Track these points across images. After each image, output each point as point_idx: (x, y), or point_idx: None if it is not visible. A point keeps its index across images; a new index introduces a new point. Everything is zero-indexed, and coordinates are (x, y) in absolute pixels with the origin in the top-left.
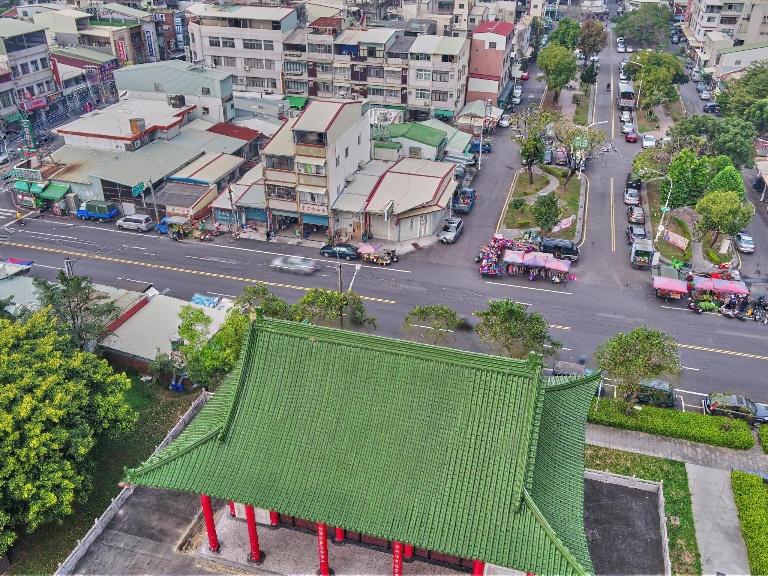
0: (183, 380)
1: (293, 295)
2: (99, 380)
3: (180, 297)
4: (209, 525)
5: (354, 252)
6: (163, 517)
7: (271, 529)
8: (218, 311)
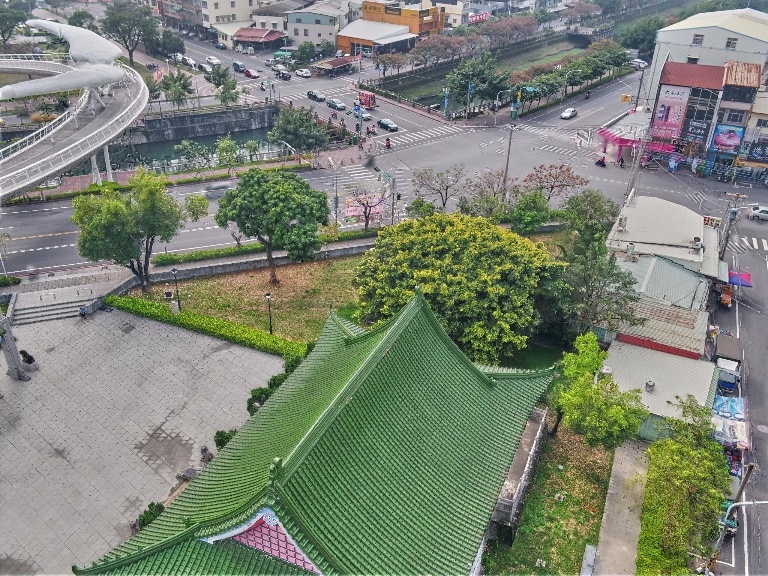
0: None
1: None
2: (494, 315)
3: (763, 402)
4: None
5: None
6: None
7: None
8: None
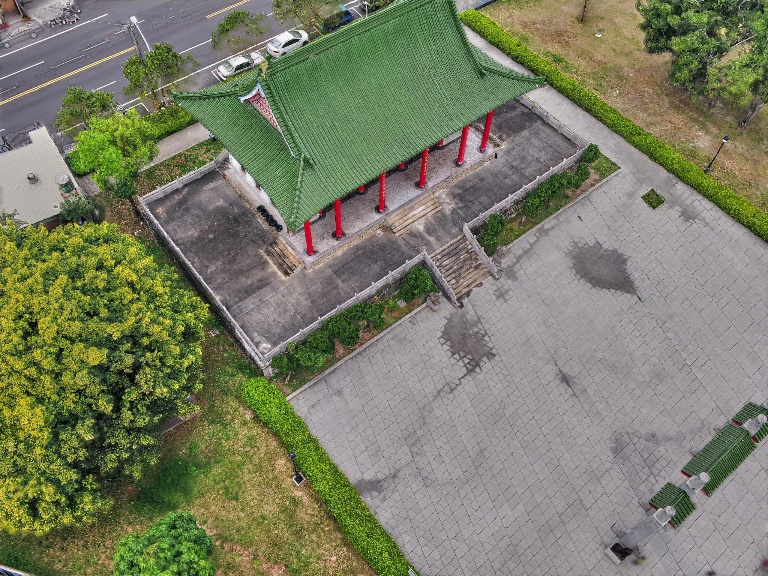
0: (89, 213)
1: (43, 97)
2: (103, 234)
3: None
4: (310, 236)
5: (36, 25)
6: (248, 275)
7: (323, 218)
8: (33, 145)
